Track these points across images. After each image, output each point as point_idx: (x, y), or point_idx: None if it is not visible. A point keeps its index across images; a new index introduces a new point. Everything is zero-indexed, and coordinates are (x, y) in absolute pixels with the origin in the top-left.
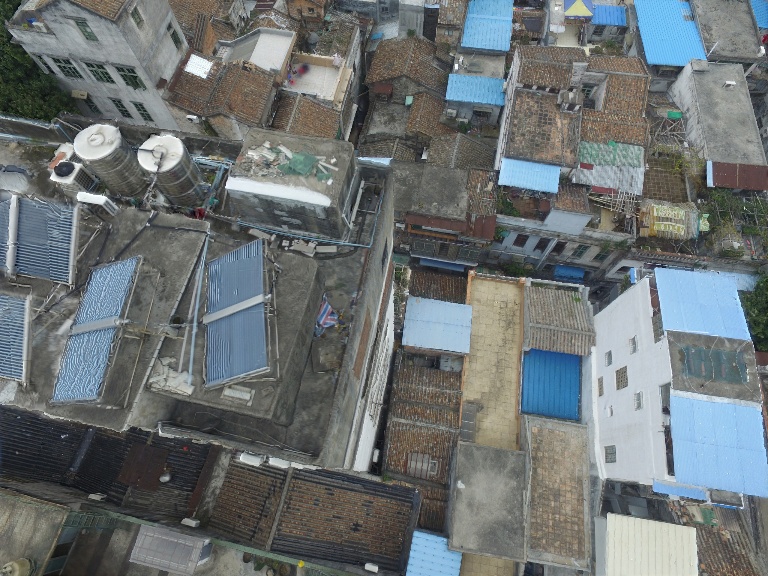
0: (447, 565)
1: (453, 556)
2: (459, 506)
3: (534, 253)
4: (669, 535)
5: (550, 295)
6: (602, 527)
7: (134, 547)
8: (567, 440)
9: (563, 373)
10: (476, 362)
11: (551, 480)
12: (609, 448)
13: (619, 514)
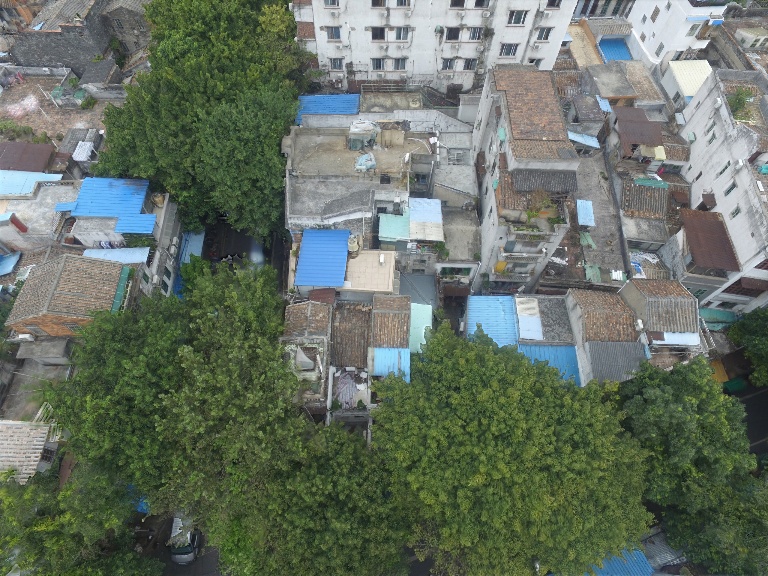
0: (603, 103)
1: (604, 100)
2: (598, 85)
3: (580, 17)
4: (697, 64)
5: (600, 20)
6: (666, 77)
7: (461, 101)
8: (634, 66)
9: (619, 50)
10: (574, 54)
11: (634, 79)
12: (658, 49)
13: (673, 61)
